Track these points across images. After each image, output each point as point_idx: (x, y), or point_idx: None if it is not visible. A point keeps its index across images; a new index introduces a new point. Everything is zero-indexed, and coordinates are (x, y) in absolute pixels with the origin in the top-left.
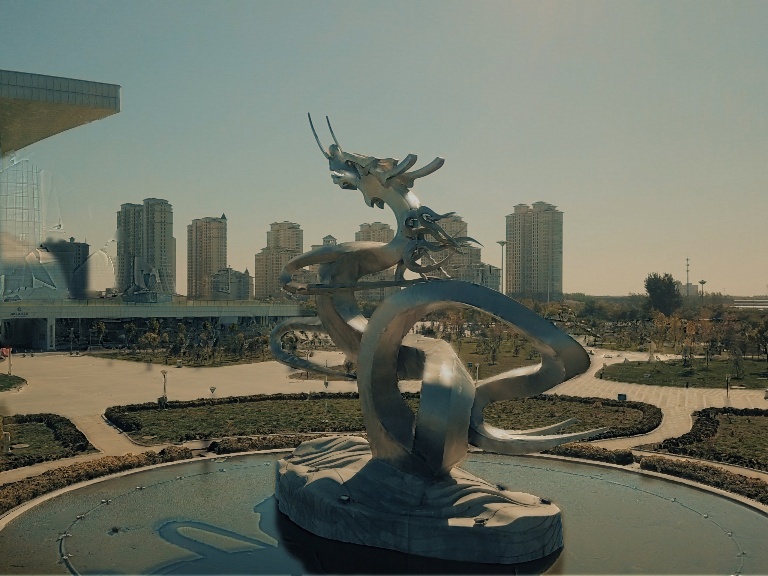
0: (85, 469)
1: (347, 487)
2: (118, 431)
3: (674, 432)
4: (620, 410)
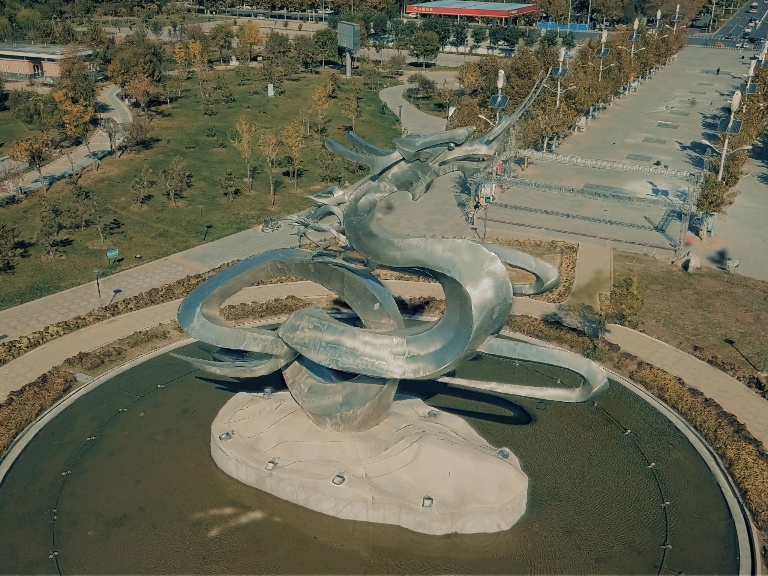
0: (738, 460)
1: None
2: None
3: None
4: None
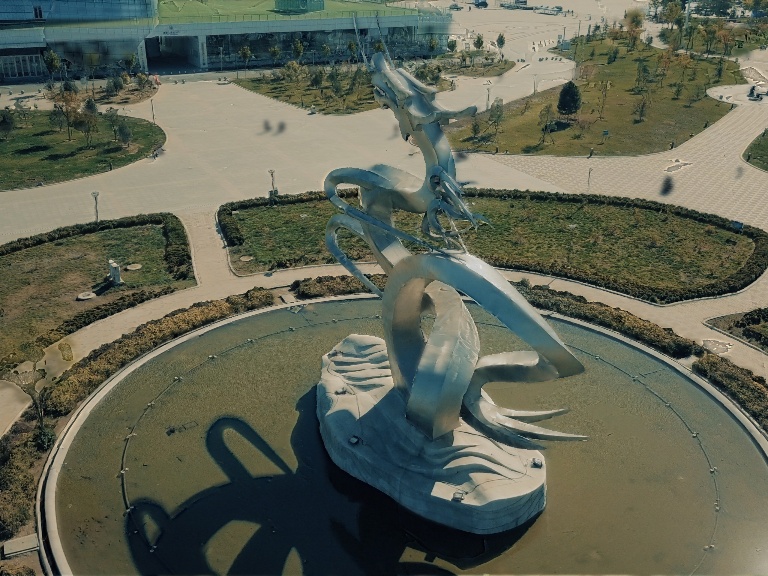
0: (171, 328)
1: (361, 423)
2: (223, 244)
3: None
4: (732, 240)
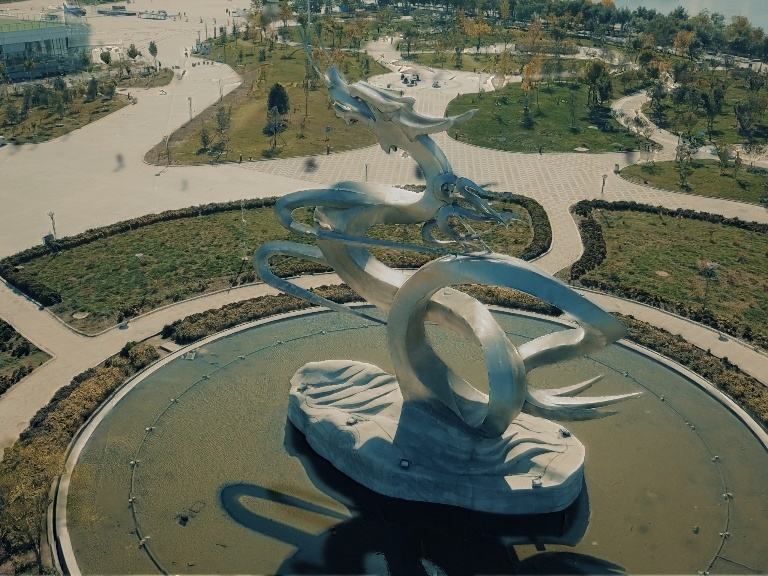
0: (77, 411)
1: (398, 446)
2: (36, 306)
3: (569, 245)
4: (506, 208)
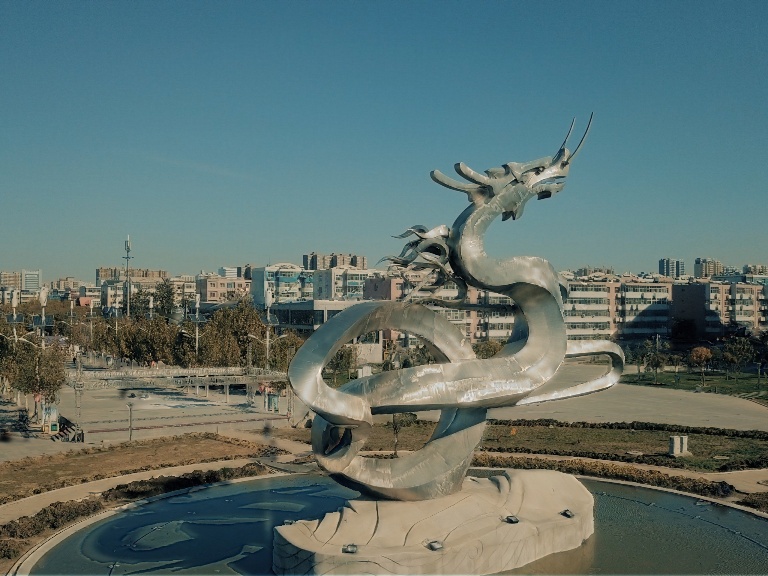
0: (584, 466)
1: None
2: None
3: None
4: None
